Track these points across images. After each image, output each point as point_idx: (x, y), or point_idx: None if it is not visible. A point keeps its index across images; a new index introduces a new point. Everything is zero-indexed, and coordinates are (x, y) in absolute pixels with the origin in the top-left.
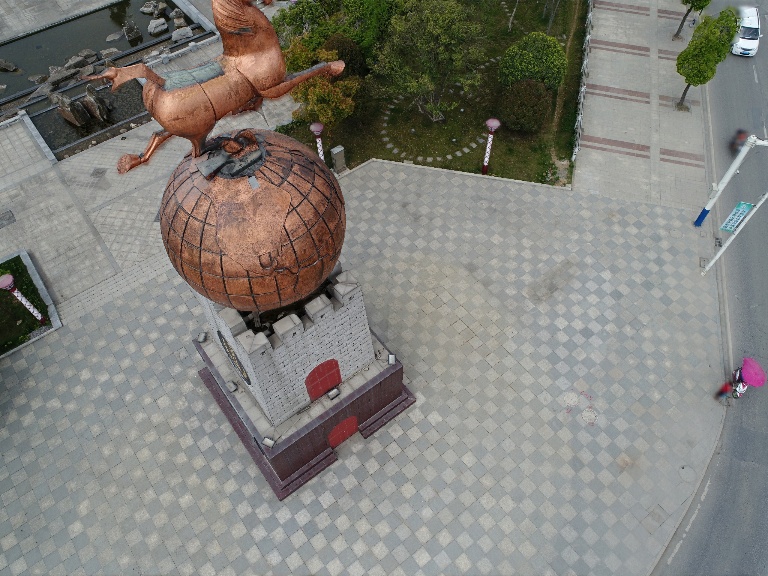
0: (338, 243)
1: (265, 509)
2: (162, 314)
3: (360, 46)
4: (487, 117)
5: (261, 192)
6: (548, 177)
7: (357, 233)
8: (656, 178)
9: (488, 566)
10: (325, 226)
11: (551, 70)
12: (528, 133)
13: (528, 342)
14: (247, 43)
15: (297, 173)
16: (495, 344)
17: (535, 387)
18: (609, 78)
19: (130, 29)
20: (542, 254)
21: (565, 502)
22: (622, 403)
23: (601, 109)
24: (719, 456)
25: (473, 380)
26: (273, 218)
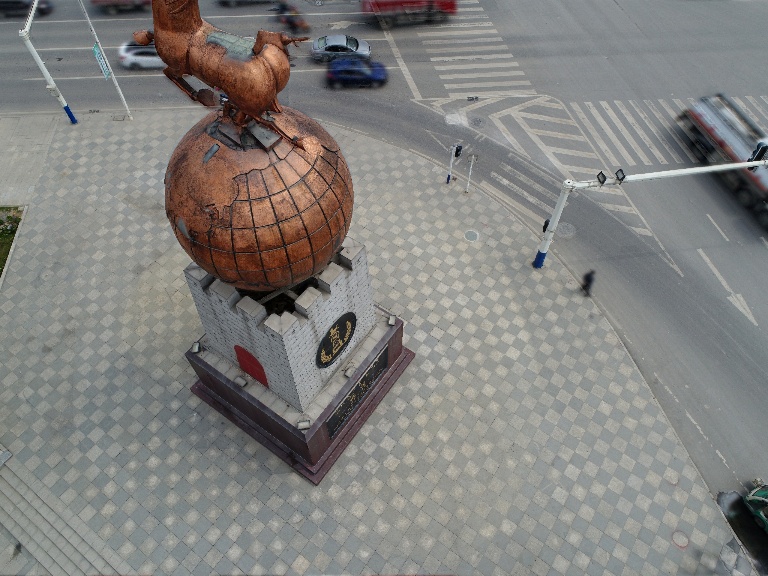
0: None
1: (425, 366)
2: None
3: None
4: None
5: None
6: (5, 228)
7: (94, 388)
8: (13, 148)
9: (407, 215)
10: None
11: None
12: None
13: None
14: None
15: None
16: None
17: None
18: None
19: None
20: (117, 218)
21: None
22: None
23: None
24: None
25: None
26: None
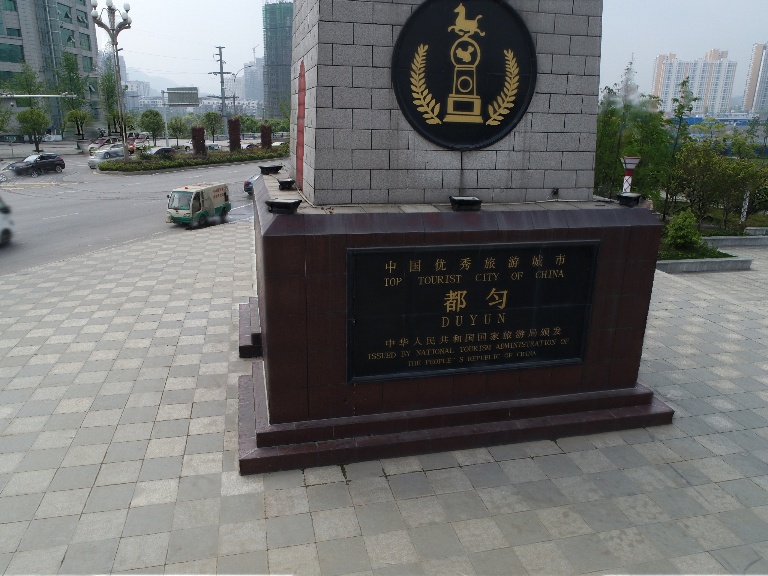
0: None
1: None
2: None
3: None
4: None
5: None
6: None
7: None
8: None
9: None
10: None
11: None
12: None
13: None
14: None
15: None
16: None
17: None
18: None
19: None
20: None
21: None
22: None
23: None
24: None
25: None
26: None
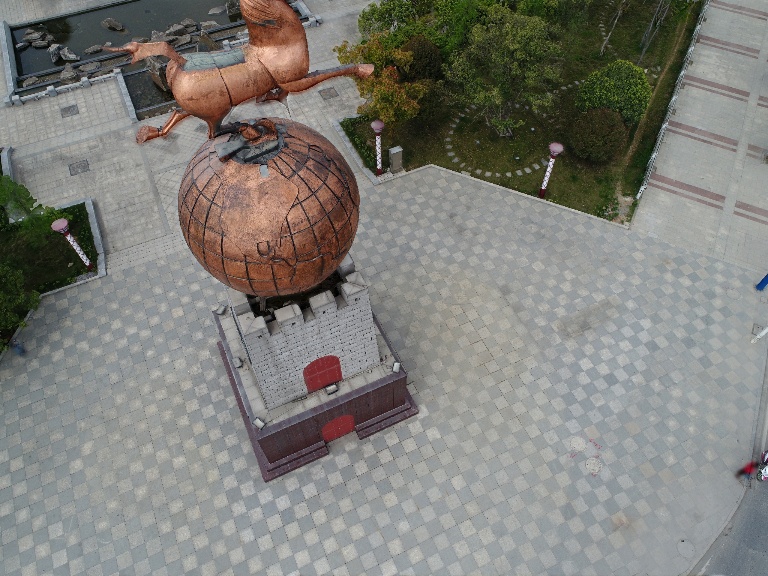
0: (343, 243)
1: (250, 486)
2: (197, 281)
3: (442, 50)
4: (557, 140)
5: (269, 181)
6: (607, 211)
7: (399, 235)
8: (725, 231)
9: None
10: (330, 225)
11: (631, 101)
12: (596, 163)
13: (546, 377)
14: (271, 35)
15: (310, 168)
16: (512, 372)
17: (543, 424)
18: (697, 118)
19: (232, 5)
20: (582, 289)
21: (547, 548)
22: (632, 459)
23: (681, 150)
24: (726, 538)
25: (481, 404)
26: (276, 208)
